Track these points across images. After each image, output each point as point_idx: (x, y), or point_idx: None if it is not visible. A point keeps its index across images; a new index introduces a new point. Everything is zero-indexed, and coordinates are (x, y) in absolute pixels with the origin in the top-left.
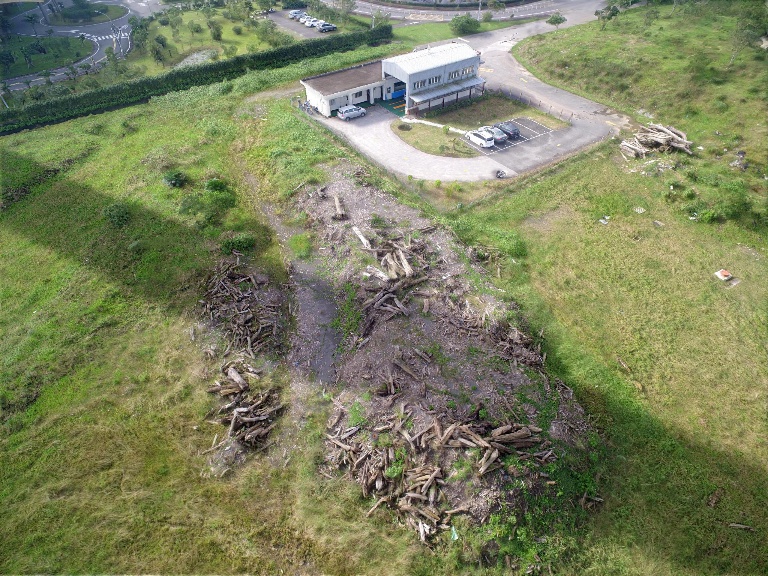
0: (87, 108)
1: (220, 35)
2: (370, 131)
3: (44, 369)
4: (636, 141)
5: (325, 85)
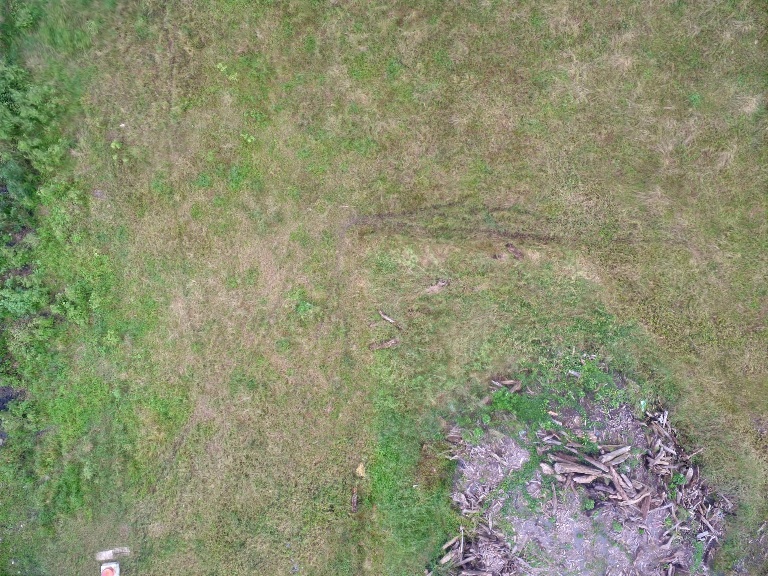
0: None
1: None
2: None
3: None
4: None
5: None
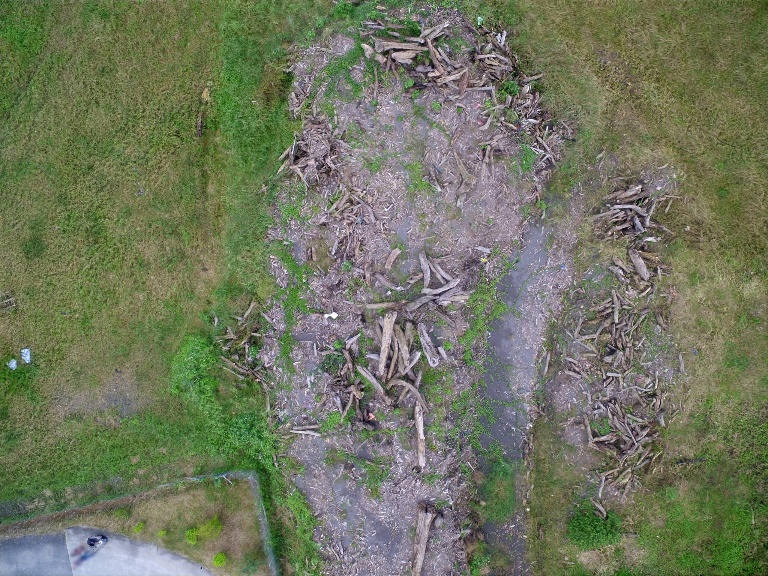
0: None
1: None
2: None
3: None
4: None
5: None
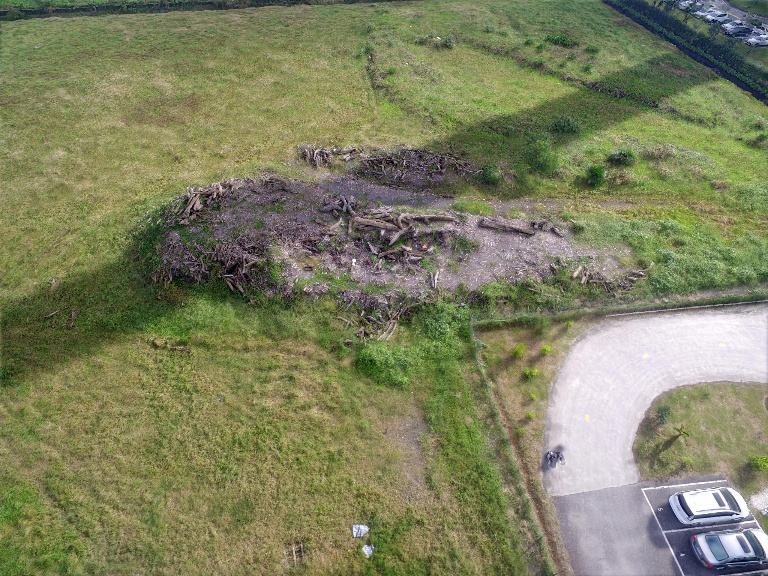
0: None
1: None
2: (761, 350)
3: (409, 102)
4: None
5: None
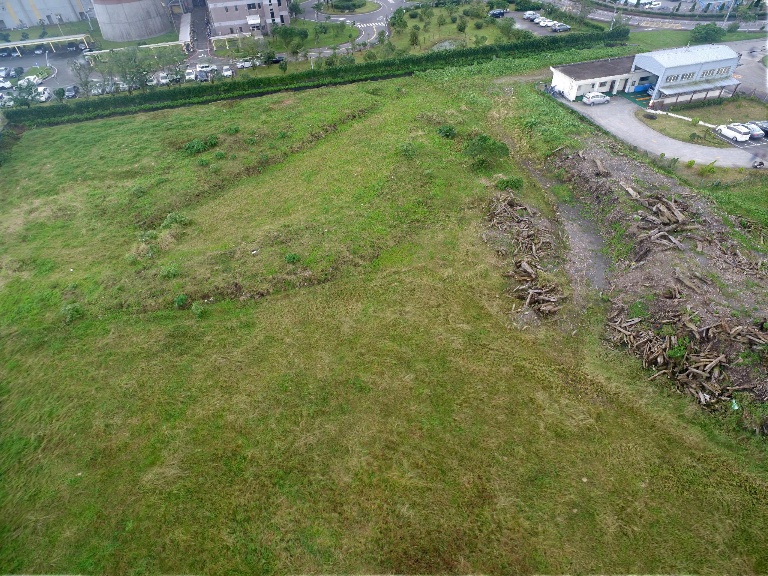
0: (366, 75)
1: (465, 28)
2: (615, 116)
3: (381, 239)
4: None
5: (575, 73)
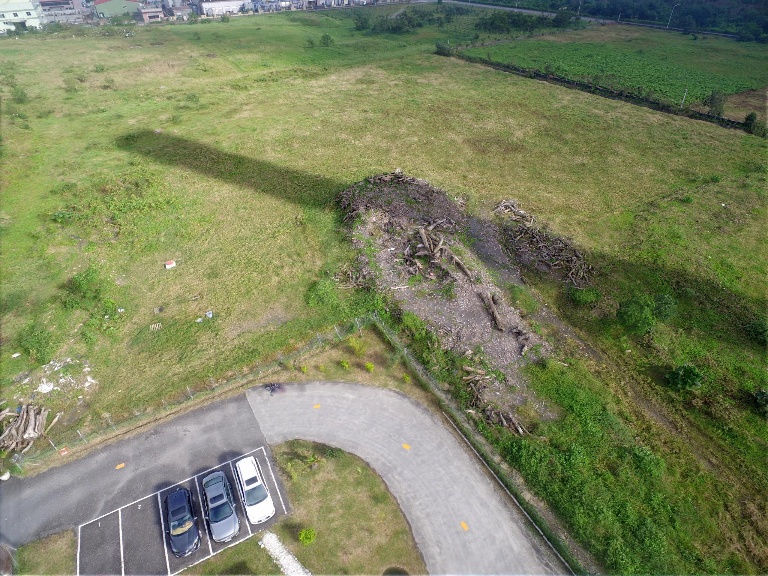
0: None
1: None
2: (483, 574)
3: None
4: (4, 436)
5: None
